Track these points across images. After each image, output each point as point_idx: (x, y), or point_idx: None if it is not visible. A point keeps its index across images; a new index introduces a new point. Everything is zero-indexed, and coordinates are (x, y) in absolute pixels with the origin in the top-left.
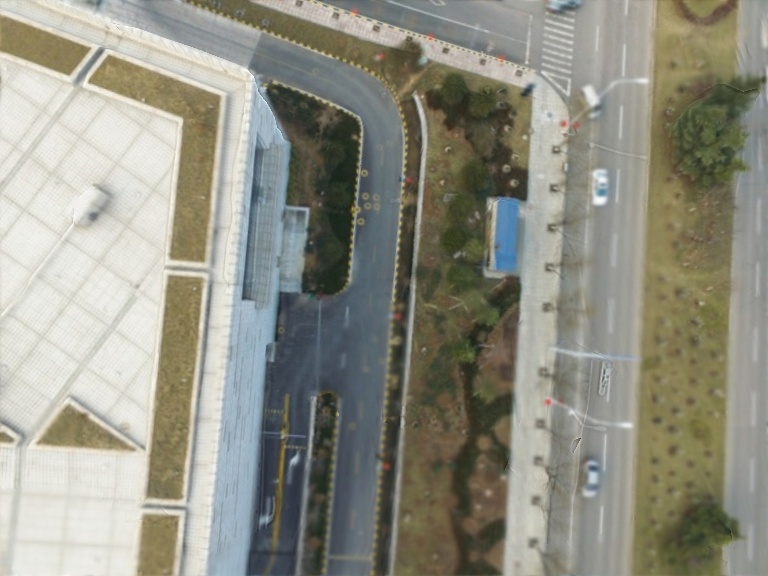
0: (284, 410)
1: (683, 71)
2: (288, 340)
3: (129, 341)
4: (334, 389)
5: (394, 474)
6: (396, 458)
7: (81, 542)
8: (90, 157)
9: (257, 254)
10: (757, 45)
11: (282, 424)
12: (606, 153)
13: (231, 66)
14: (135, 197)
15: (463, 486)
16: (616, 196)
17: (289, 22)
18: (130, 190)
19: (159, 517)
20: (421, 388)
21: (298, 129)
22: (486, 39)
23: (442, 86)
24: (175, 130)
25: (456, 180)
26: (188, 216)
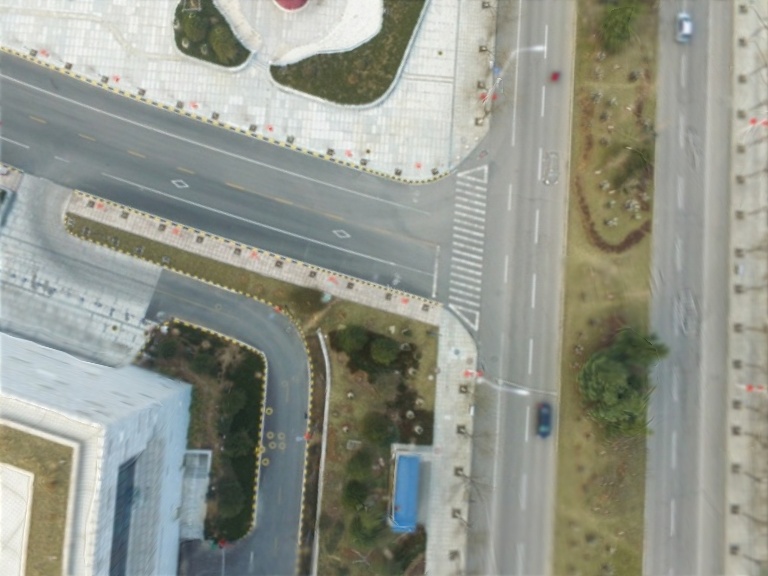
0: None
1: (594, 303)
2: None
3: None
4: None
5: None
6: None
7: None
8: None
9: (132, 564)
10: (671, 271)
11: None
12: (515, 390)
13: (82, 422)
14: None
15: None
16: (526, 435)
17: (190, 259)
18: None
19: None
20: None
21: (199, 370)
22: (392, 272)
23: (345, 327)
24: (27, 484)
25: (359, 427)
26: None
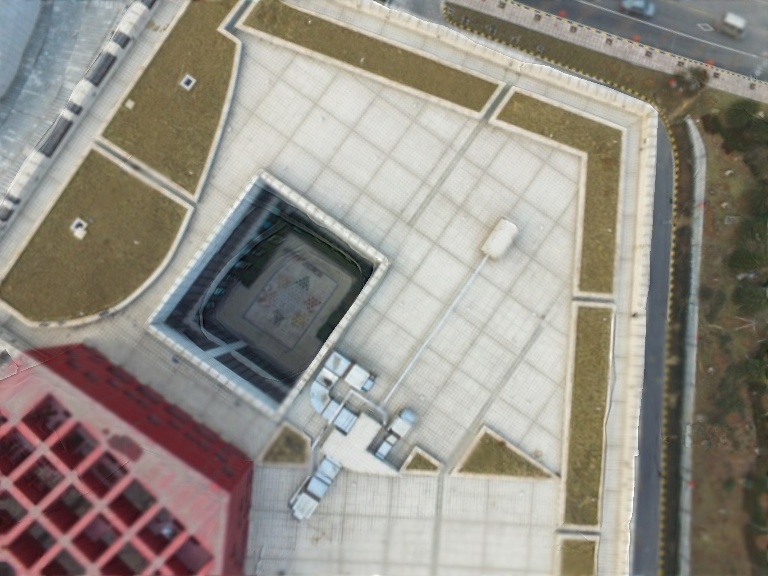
0: None
1: None
2: None
3: (537, 370)
4: None
5: (682, 492)
6: (683, 476)
7: (501, 567)
8: (495, 191)
9: None
10: None
11: None
12: None
13: (637, 102)
14: (539, 230)
15: (755, 504)
16: None
17: (564, 48)
18: (534, 223)
19: (578, 543)
20: (709, 407)
21: None
22: (754, 64)
23: (719, 110)
24: (578, 164)
25: (738, 203)
26: (596, 248)
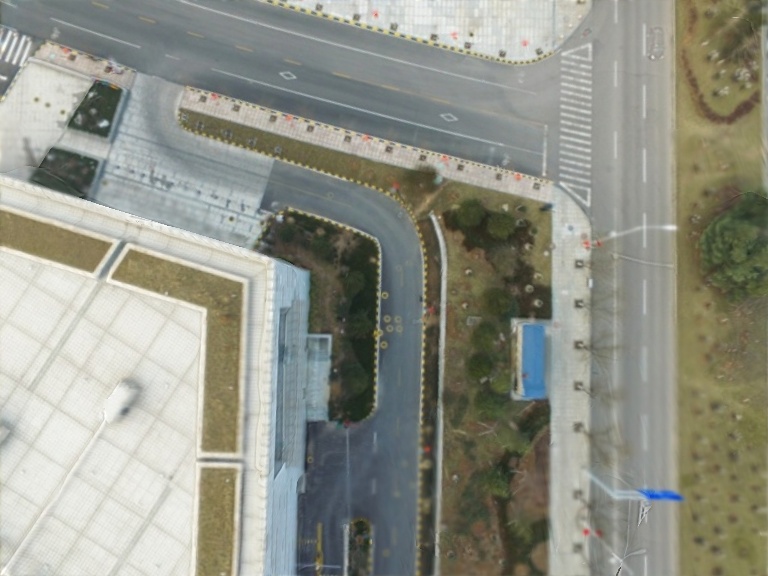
0: (317, 539)
1: (707, 174)
2: (318, 469)
3: (165, 533)
4: (366, 516)
5: None
6: None
7: None
8: (117, 351)
9: (285, 416)
10: None
11: (316, 554)
12: (631, 264)
13: (251, 255)
14: (163, 388)
15: None
16: (644, 307)
17: (301, 149)
18: (158, 381)
19: None
20: (454, 516)
21: (316, 256)
22: (501, 153)
23: (459, 206)
24: (199, 320)
25: (479, 303)
26: (217, 408)
